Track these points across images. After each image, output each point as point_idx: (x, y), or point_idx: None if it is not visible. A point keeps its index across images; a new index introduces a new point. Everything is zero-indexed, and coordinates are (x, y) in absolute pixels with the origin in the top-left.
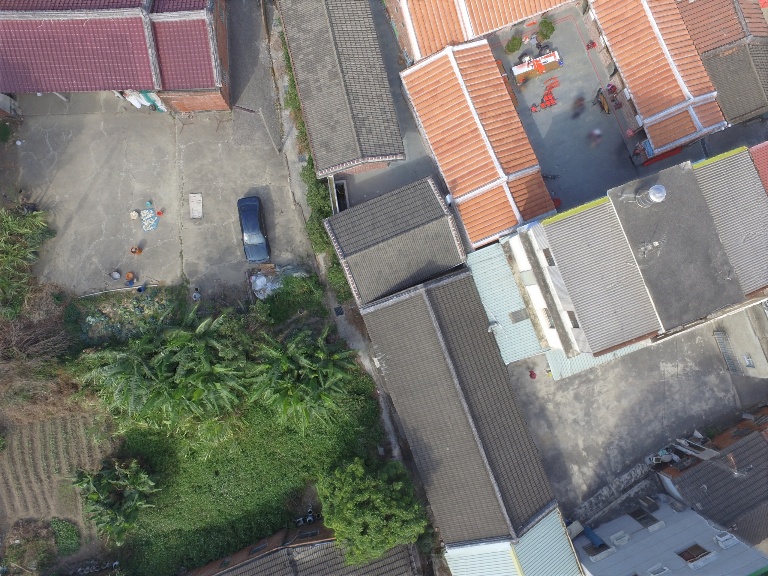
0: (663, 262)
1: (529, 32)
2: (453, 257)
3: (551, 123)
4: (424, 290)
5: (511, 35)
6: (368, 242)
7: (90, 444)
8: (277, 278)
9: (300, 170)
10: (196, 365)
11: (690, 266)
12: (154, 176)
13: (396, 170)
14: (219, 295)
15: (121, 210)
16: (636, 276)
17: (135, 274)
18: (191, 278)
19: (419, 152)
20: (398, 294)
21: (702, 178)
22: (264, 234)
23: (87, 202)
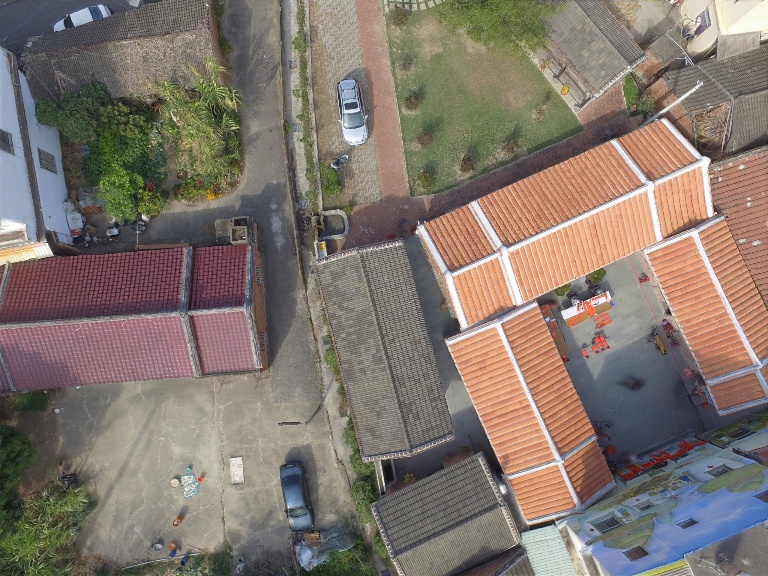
0: None
1: None
2: (507, 540)
3: (603, 363)
4: None
5: None
6: (419, 536)
7: None
8: (322, 551)
9: (342, 425)
10: None
11: None
12: (193, 439)
13: None
14: (263, 562)
15: (161, 477)
16: None
17: (177, 543)
18: (234, 545)
19: (465, 402)
20: None
21: None
22: (308, 505)
23: (127, 470)
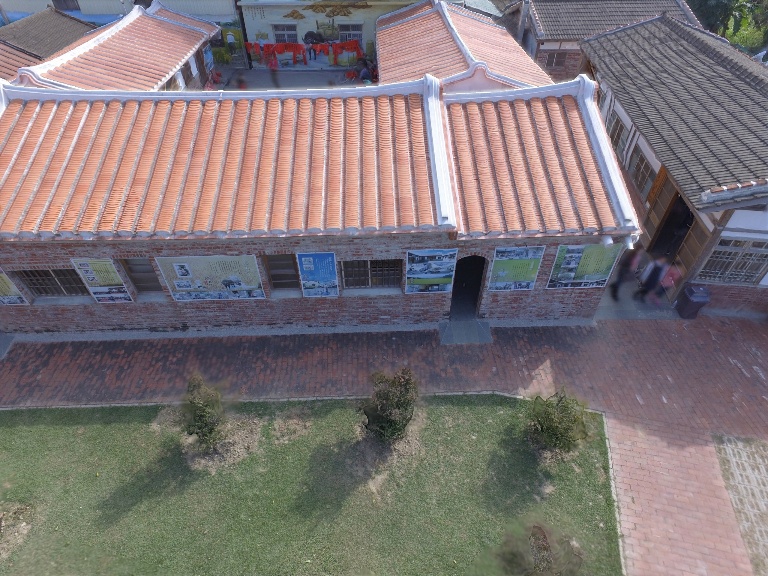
0: None
1: None
2: None
3: None
4: None
5: None
6: (642, 3)
7: None
8: None
9: None
10: None
11: None
12: None
13: None
14: None
15: None
16: None
17: None
18: None
19: None
20: None
21: None
22: None
23: None
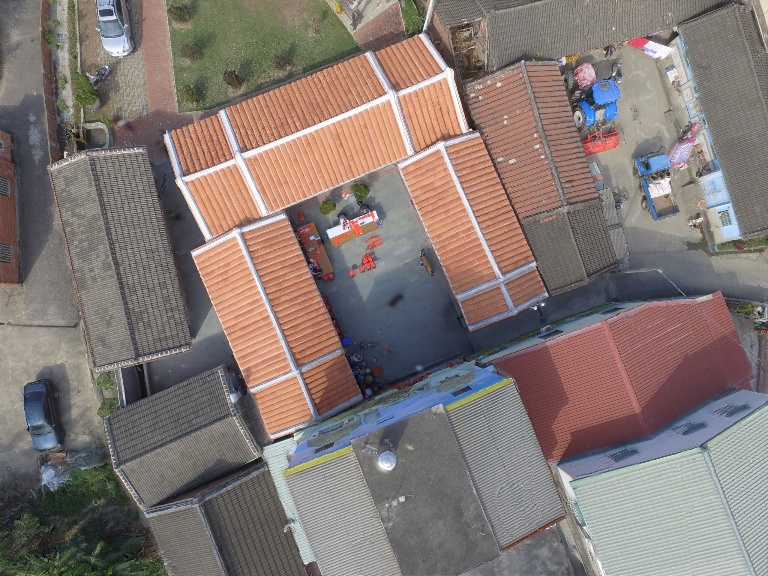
0: (410, 519)
1: (349, 187)
2: (245, 453)
3: (373, 285)
4: (198, 506)
5: (329, 191)
6: (146, 446)
7: None
8: (66, 470)
9: None
10: None
11: (439, 522)
12: None
13: (203, 342)
14: (9, 484)
15: None
16: (383, 532)
17: None
18: None
19: None
20: (178, 503)
21: (458, 420)
22: (52, 423)
23: None
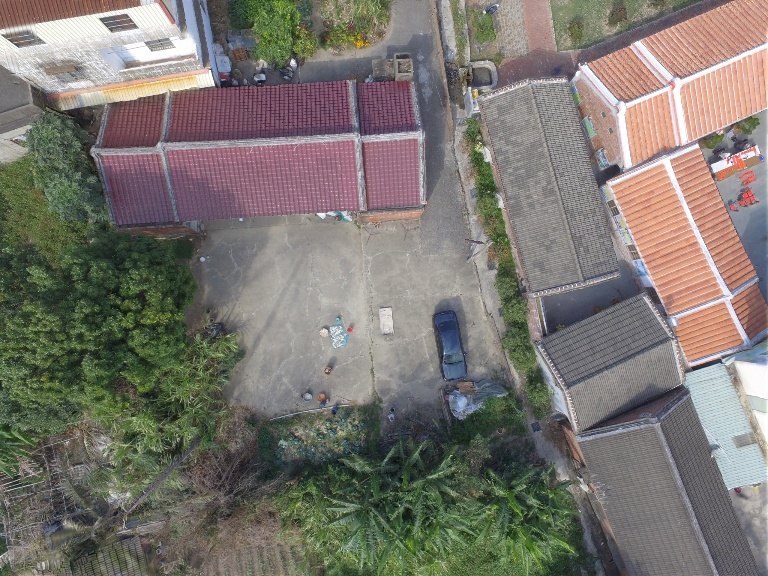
0: None
1: None
2: (673, 379)
3: (749, 220)
4: (659, 424)
5: None
6: (590, 369)
7: (287, 573)
8: (478, 398)
9: (490, 278)
10: (435, 517)
11: None
12: (341, 290)
13: None
14: (413, 414)
15: (309, 327)
16: None
17: (326, 394)
18: (384, 397)
19: None
20: (624, 424)
21: None
22: (463, 352)
23: (275, 320)
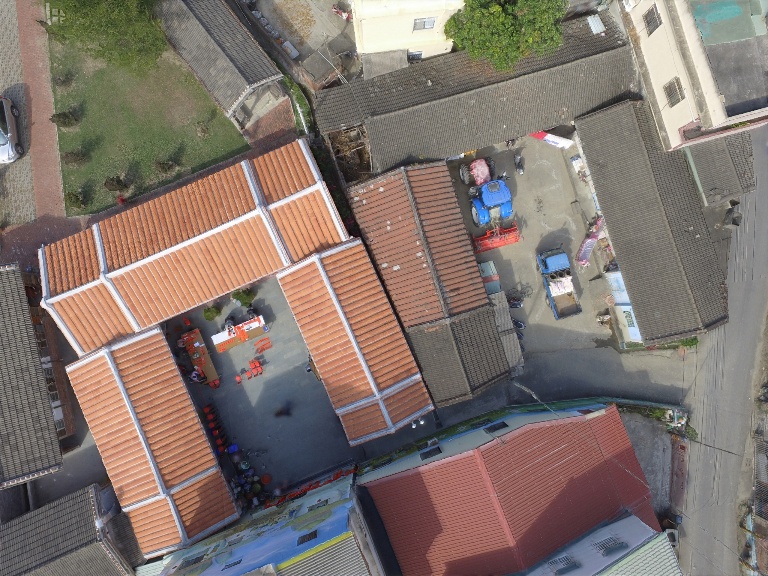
0: None
1: None
2: (116, 575)
3: (262, 389)
4: None
5: None
6: (12, 572)
7: None
8: None
9: None
10: None
11: None
12: None
13: (89, 450)
14: None
15: None
16: None
17: None
18: None
19: None
20: None
21: None
22: None
23: None
